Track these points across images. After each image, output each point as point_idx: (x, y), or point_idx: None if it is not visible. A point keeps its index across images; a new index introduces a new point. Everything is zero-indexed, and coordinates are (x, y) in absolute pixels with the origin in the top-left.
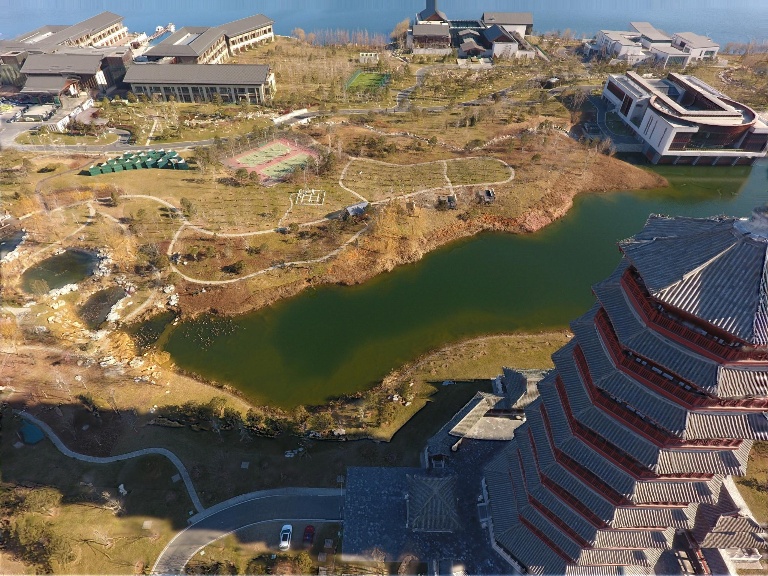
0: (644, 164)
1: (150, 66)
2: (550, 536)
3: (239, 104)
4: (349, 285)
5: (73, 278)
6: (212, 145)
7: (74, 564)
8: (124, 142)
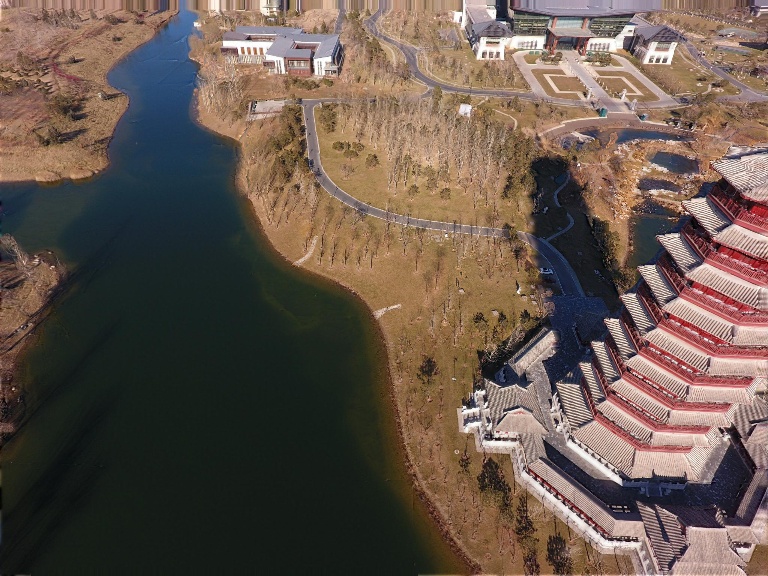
0: None
1: None
2: (594, 354)
3: None
4: None
5: (673, 168)
6: None
7: (508, 205)
8: None
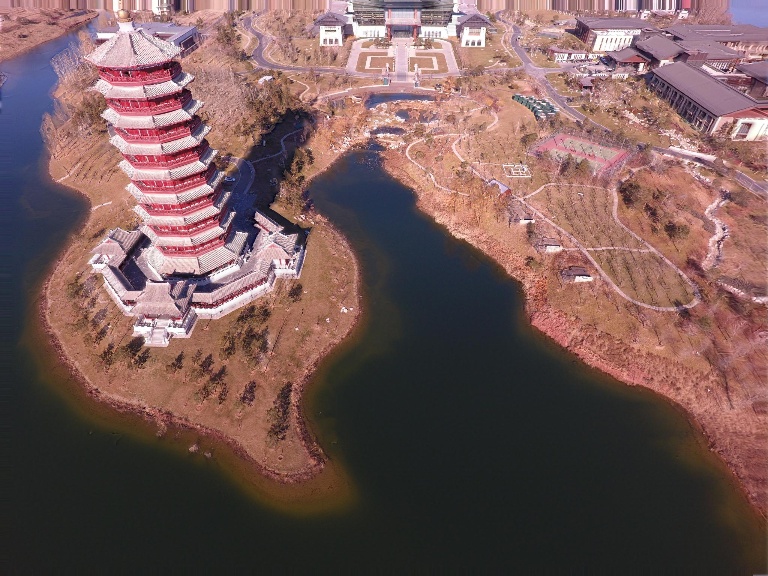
0: None
1: (684, 67)
2: None
3: (691, 127)
4: (416, 204)
5: (410, 119)
6: (567, 118)
7: None
8: (570, 100)
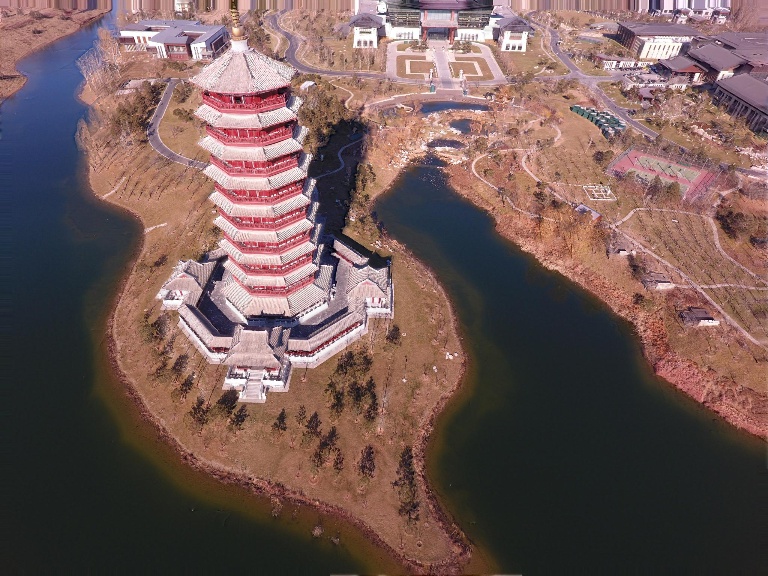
0: None
1: (753, 80)
2: None
3: (767, 144)
4: (495, 228)
5: (466, 131)
6: (640, 134)
7: None
8: (631, 112)
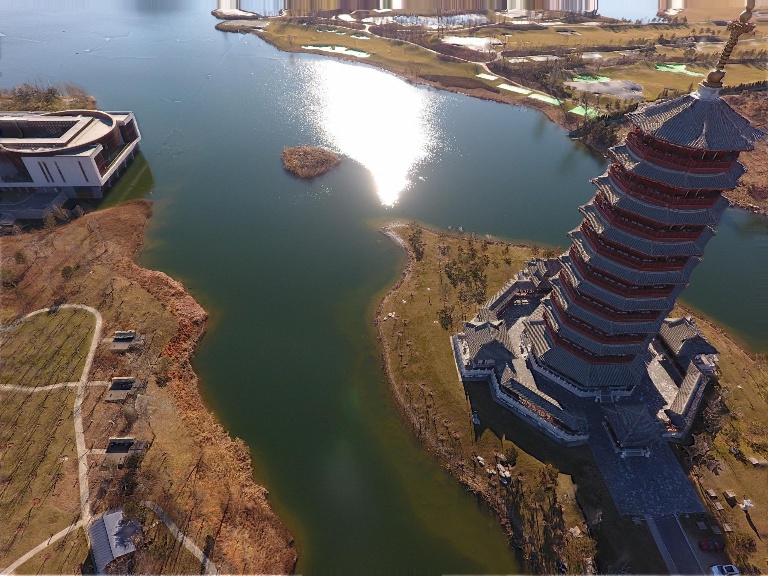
0: (87, 206)
1: None
2: None
3: None
4: (297, 557)
5: None
6: None
7: None
8: None
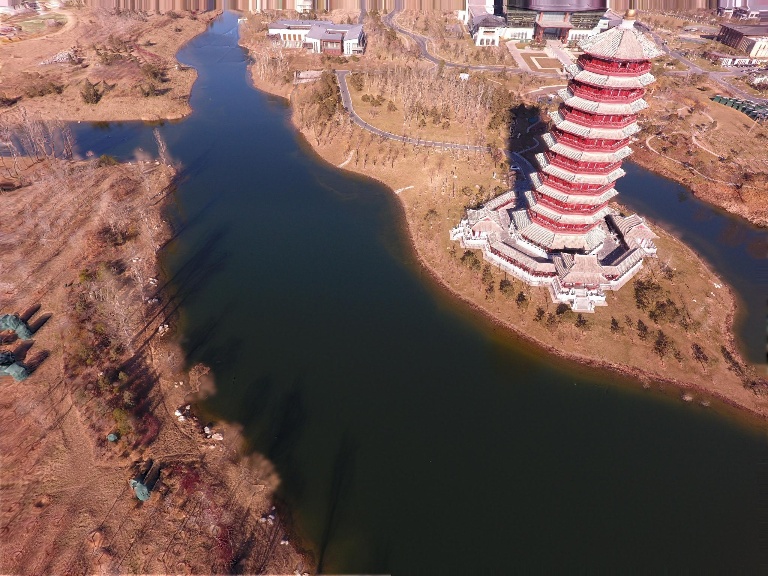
0: None
1: None
2: None
3: None
4: (694, 195)
5: None
6: None
7: None
8: (767, 102)
